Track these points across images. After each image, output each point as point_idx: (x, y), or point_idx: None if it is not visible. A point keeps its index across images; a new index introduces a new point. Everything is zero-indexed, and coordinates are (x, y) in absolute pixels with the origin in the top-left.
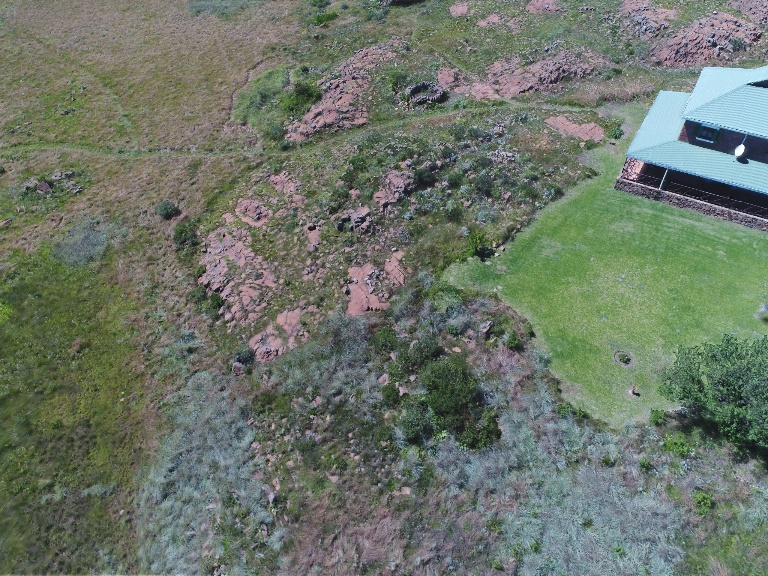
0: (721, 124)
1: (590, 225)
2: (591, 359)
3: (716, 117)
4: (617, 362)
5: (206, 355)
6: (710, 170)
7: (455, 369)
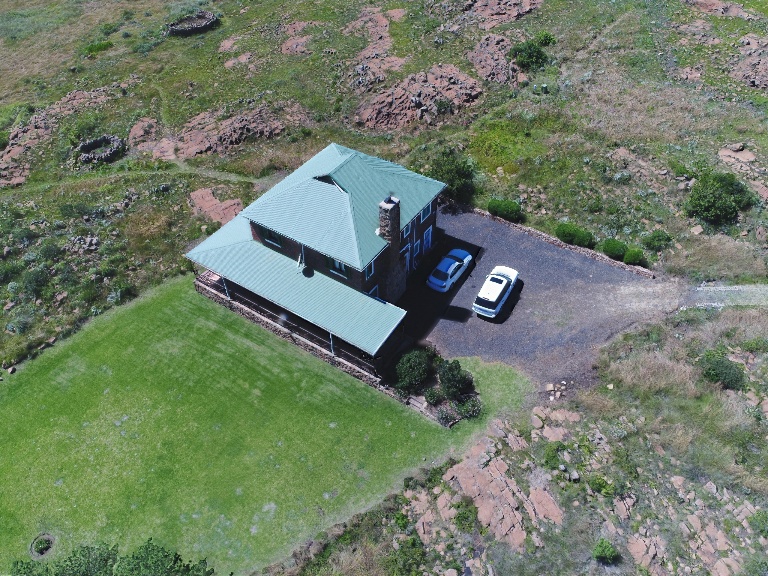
0: (273, 228)
1: (135, 342)
2: (2, 544)
3: (271, 218)
4: (30, 551)
5: None
6: (263, 284)
7: None
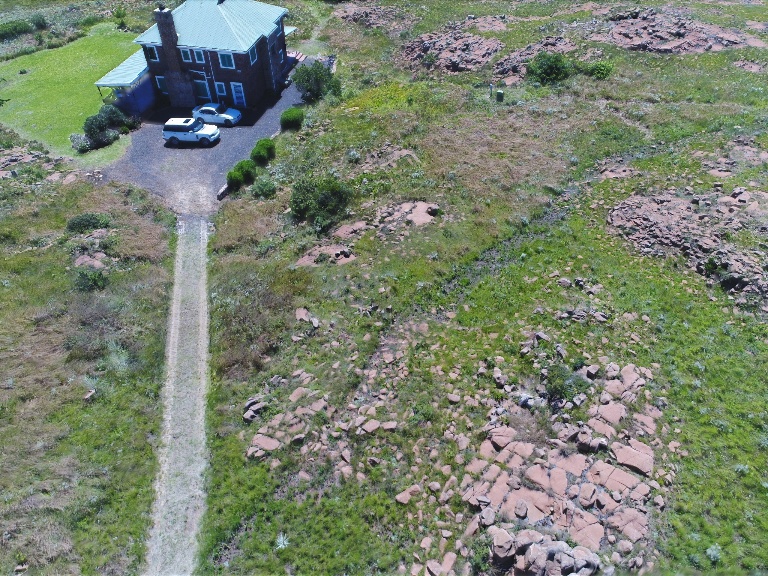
0: None
1: None
2: (26, 64)
3: None
4: None
5: (83, 7)
6: None
7: (14, 22)
